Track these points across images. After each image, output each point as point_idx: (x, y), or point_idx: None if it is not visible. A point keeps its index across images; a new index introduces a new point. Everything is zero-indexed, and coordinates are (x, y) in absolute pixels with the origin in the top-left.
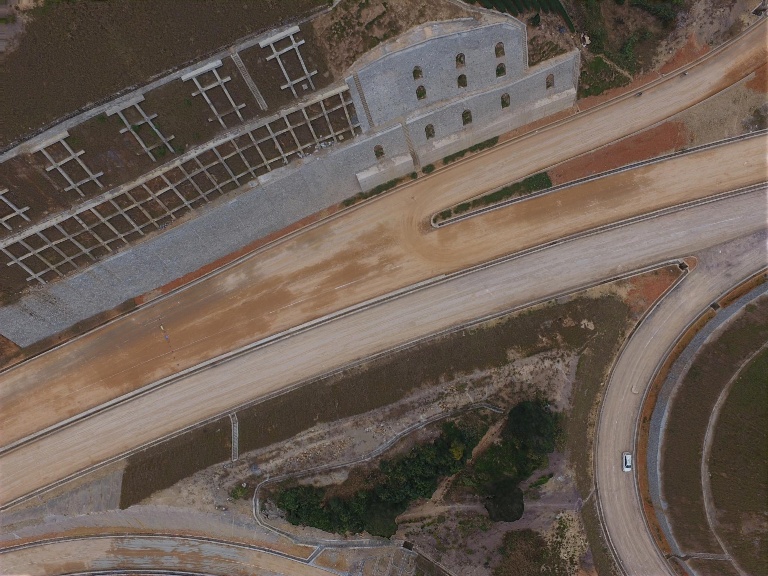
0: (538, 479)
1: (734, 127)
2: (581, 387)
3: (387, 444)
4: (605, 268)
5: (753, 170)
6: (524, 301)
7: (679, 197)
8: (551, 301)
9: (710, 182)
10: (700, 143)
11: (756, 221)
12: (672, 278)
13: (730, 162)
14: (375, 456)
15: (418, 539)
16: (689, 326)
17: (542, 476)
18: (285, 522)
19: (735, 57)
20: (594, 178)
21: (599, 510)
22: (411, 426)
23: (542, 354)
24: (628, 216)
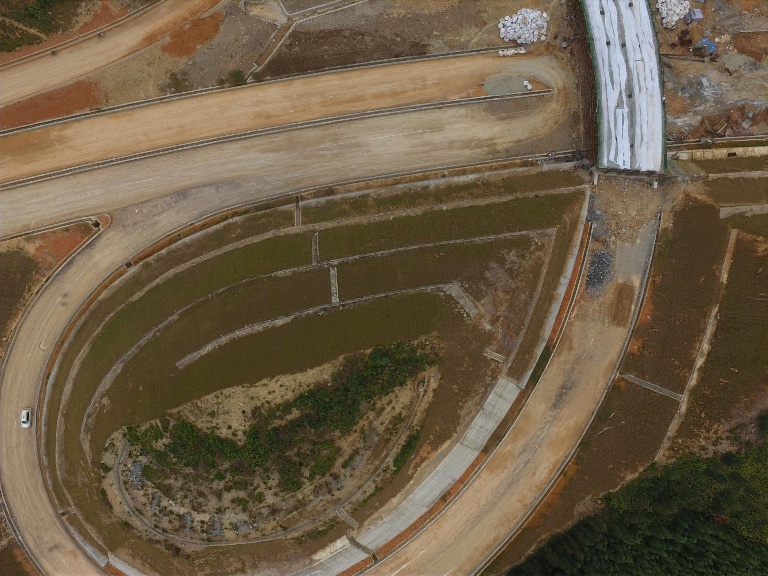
0: None
1: (150, 89)
2: None
3: None
4: (18, 223)
5: (173, 132)
6: None
7: (96, 156)
8: None
9: (128, 142)
10: (116, 103)
11: (174, 182)
12: (83, 235)
13: (149, 123)
14: None
15: None
16: (101, 283)
17: None
18: None
19: (154, 21)
20: (5, 133)
21: None
22: None
23: None
24: (42, 172)
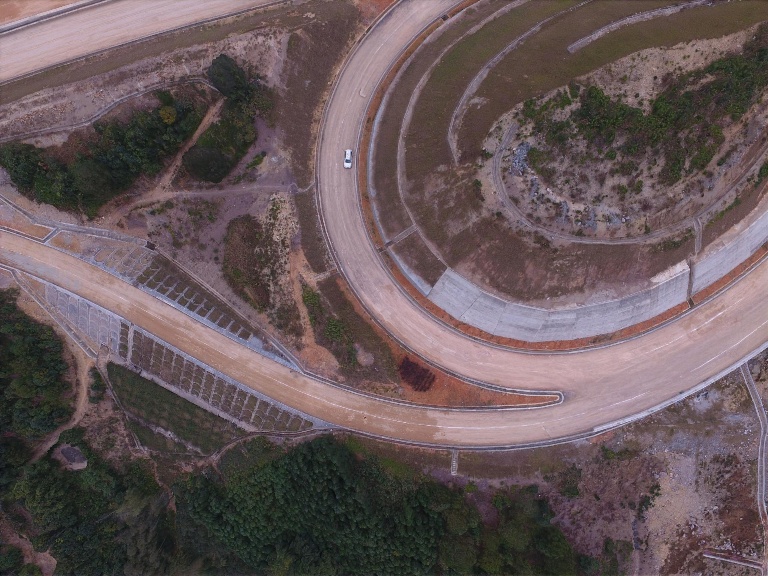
0: (253, 159)
1: None
2: (298, 72)
3: (106, 110)
4: None
5: None
6: (262, 3)
7: None
8: (287, 3)
9: None
10: None
11: None
12: None
13: None
14: (94, 121)
15: (159, 239)
16: (418, 35)
17: (256, 155)
18: (17, 193)
19: None
20: None
21: (318, 202)
22: (129, 94)
23: (256, 30)
24: None
